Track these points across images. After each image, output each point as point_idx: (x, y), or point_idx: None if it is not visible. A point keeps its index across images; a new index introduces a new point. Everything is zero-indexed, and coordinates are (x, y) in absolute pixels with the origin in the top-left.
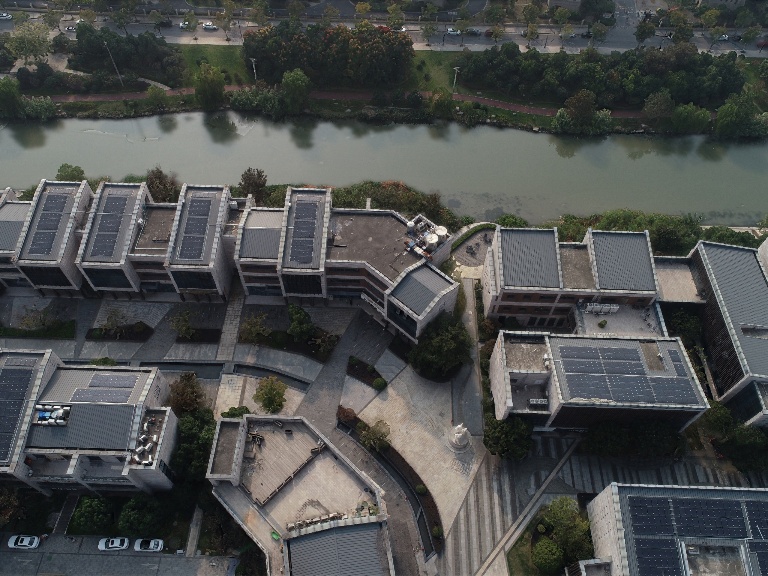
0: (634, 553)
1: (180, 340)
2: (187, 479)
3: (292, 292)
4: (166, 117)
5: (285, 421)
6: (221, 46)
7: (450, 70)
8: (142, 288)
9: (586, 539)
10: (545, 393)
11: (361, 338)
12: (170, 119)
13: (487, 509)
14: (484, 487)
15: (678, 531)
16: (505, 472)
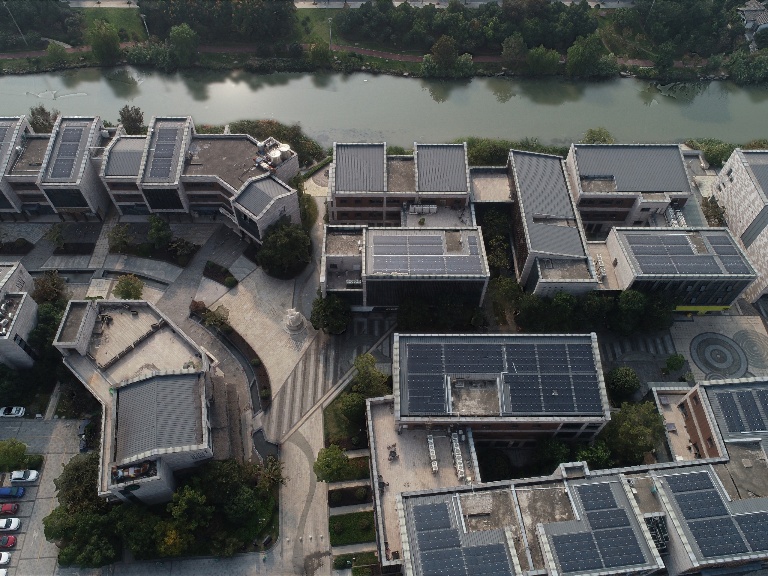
0: (407, 387)
1: (57, 252)
2: (46, 356)
3: (157, 208)
4: (67, 72)
5: (133, 305)
6: (122, 8)
7: (332, 25)
8: (25, 210)
9: (388, 392)
10: (360, 275)
11: (220, 247)
12: (70, 74)
13: (312, 376)
14: (312, 360)
15: (446, 369)
16: (332, 347)
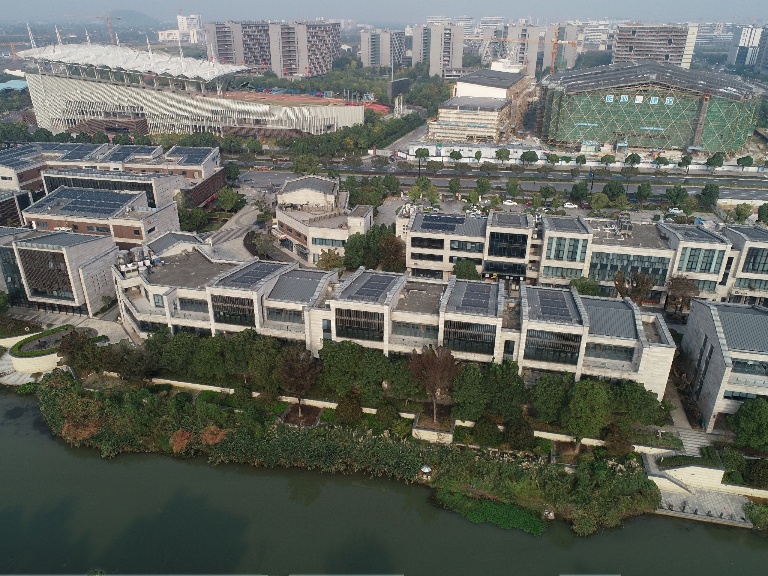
0: None
1: None
2: None
3: None
4: None
5: None
6: None
7: None
8: None
9: None
10: None
11: None
12: None
13: None
14: None
15: None
16: None
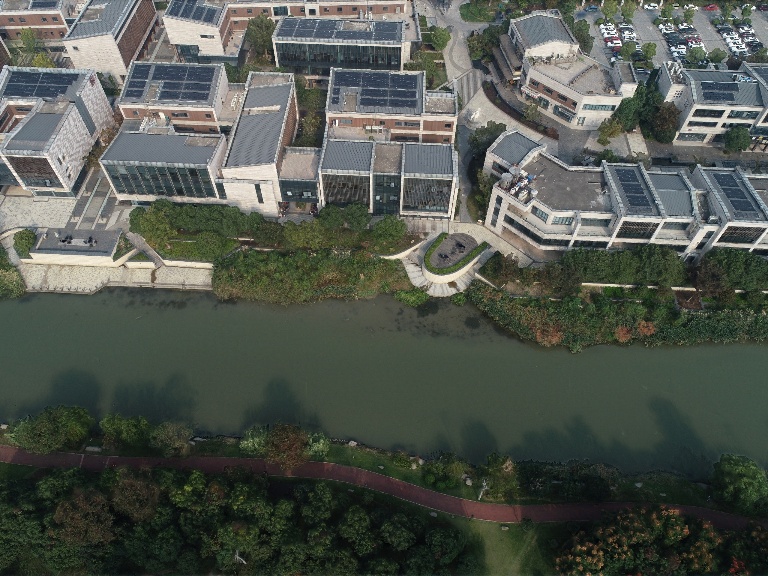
0: None
1: None
2: None
3: None
4: None
5: None
6: None
7: (485, 575)
8: None
9: None
10: None
11: None
12: None
13: None
14: None
15: (373, 33)
16: None
